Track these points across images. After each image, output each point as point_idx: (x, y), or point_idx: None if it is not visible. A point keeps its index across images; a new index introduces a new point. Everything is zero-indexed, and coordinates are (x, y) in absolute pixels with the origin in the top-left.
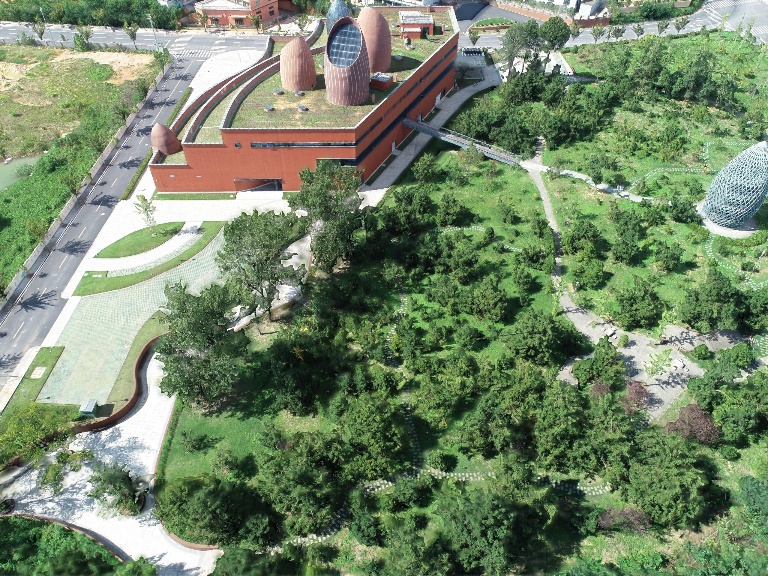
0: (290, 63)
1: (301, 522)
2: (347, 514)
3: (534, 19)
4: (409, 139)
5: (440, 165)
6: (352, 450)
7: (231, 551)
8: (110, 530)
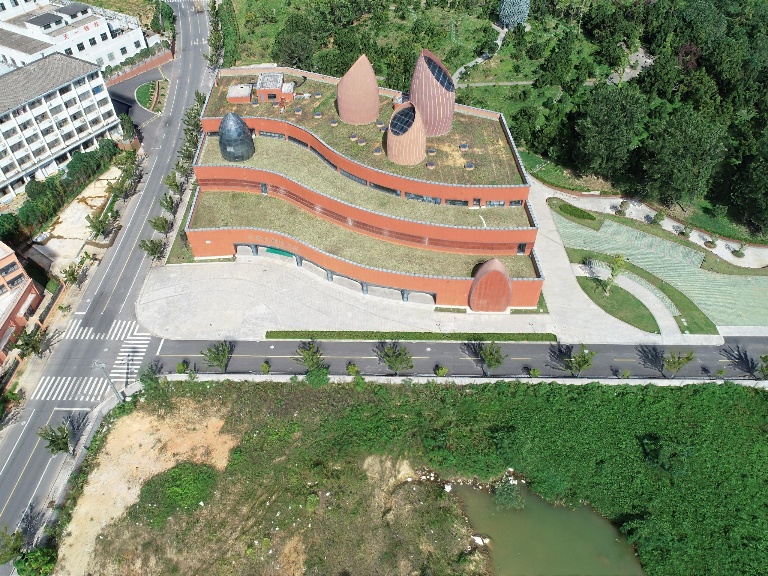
0: None
1: None
2: None
3: (144, 73)
4: None
5: None
6: None
7: None
8: None
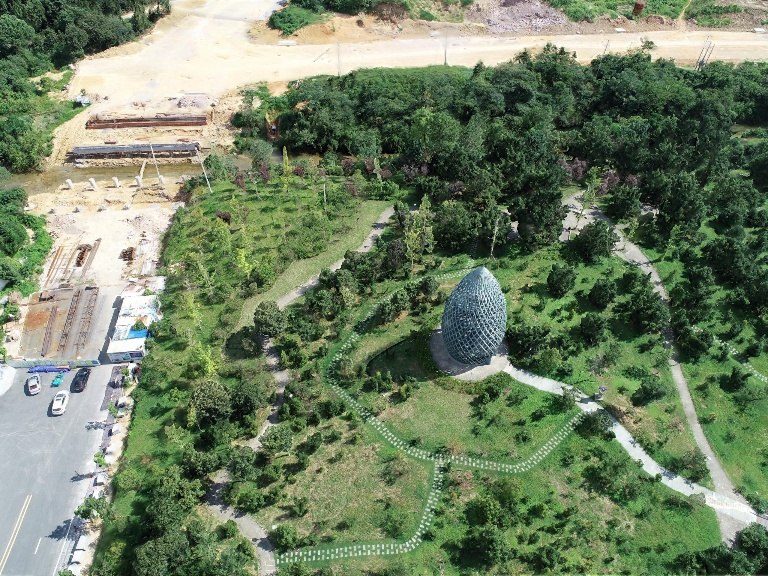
0: None
1: None
2: None
3: None
4: None
5: None
6: None
7: None
8: None
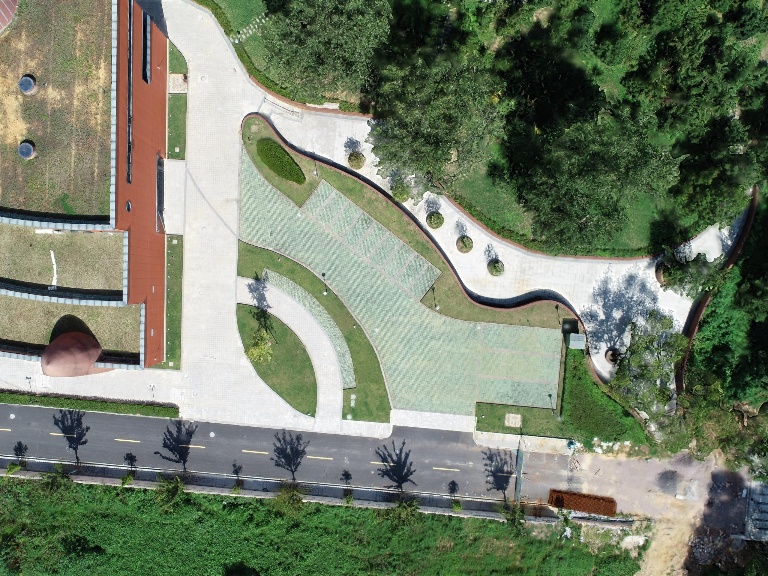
0: None
1: (736, 88)
2: (714, 51)
3: None
4: None
5: None
6: (654, 42)
7: (767, 149)
8: None
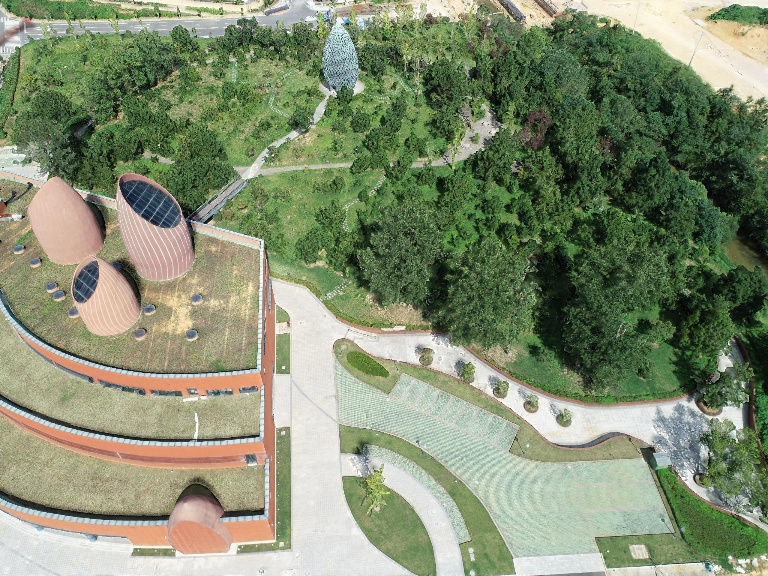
0: (121, 290)
1: None
2: None
3: None
4: None
5: None
6: None
7: None
8: (736, 415)
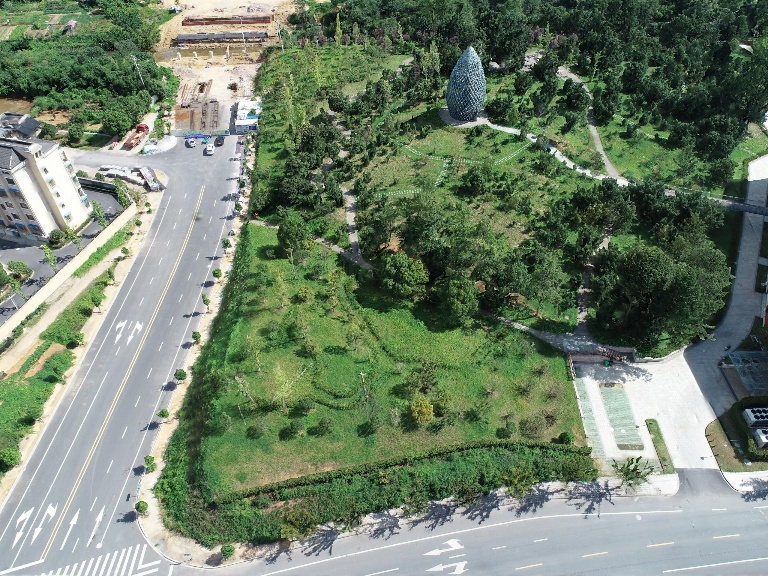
0: None
1: None
2: None
3: None
4: (767, 237)
5: (712, 196)
6: None
7: None
8: None
